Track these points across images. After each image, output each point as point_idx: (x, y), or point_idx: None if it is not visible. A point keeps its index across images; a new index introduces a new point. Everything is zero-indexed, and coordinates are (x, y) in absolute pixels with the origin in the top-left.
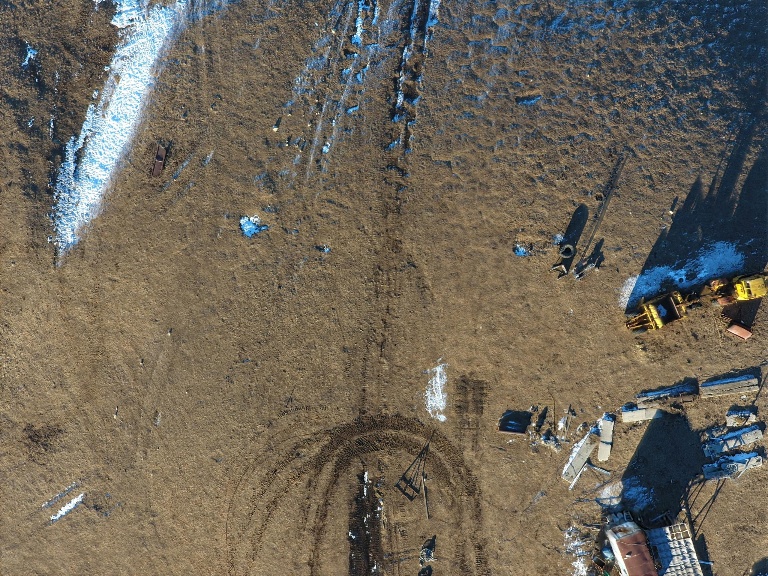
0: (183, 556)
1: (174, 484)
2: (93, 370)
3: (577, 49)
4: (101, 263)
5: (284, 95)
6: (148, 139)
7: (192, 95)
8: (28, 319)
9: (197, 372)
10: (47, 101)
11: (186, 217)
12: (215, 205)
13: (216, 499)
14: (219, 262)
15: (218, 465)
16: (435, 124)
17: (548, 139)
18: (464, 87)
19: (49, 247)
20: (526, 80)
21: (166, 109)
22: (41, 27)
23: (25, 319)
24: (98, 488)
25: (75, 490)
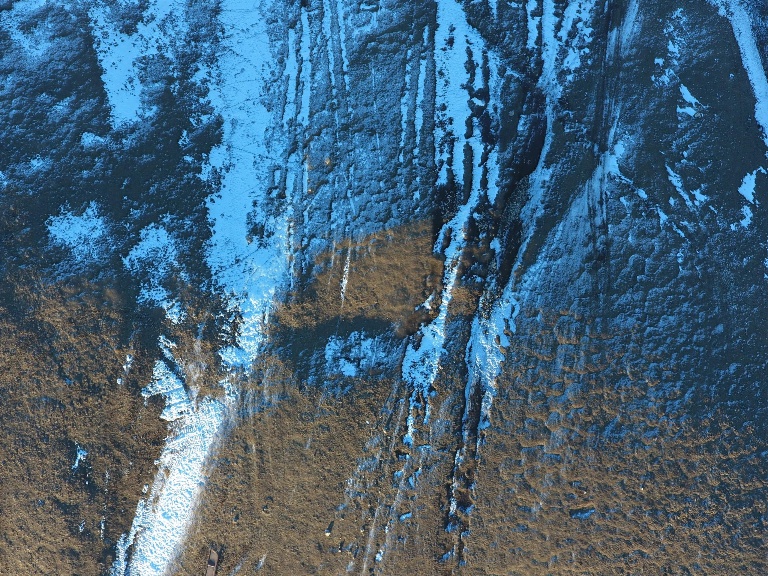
0: None
1: None
2: None
3: (630, 459)
4: None
5: (336, 497)
6: (200, 542)
7: (243, 497)
8: None
9: None
10: (97, 503)
11: None
12: None
13: None
14: None
15: None
16: (489, 536)
17: (603, 556)
18: (517, 497)
19: None
20: (580, 492)
21: (217, 511)
22: (90, 427)
23: None
24: None
25: None
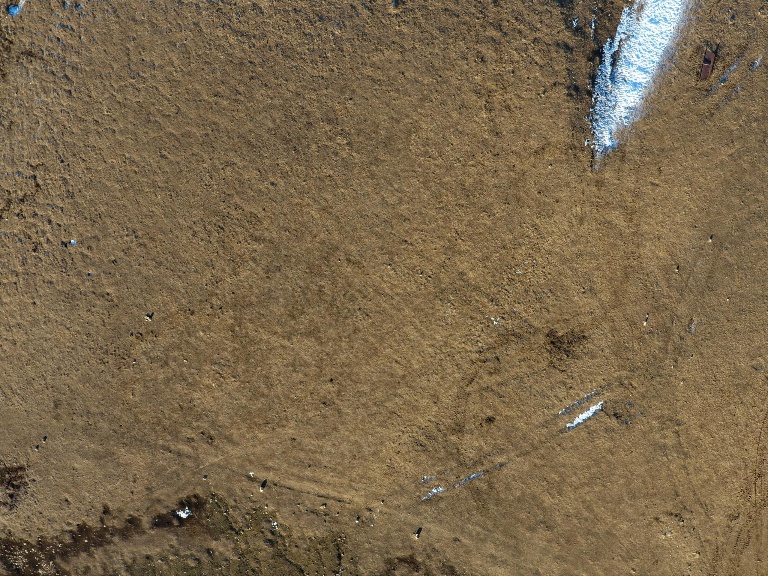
0: (707, 466)
1: (707, 392)
2: (625, 276)
3: None
4: (643, 167)
5: None
6: (694, 42)
7: None
8: (559, 223)
9: (740, 279)
10: (589, 1)
11: (734, 122)
12: (764, 110)
13: (752, 408)
14: (767, 168)
15: (758, 374)
16: None
17: None
18: None
19: (586, 150)
20: None
21: (712, 12)
22: None
23: (556, 223)
24: (620, 396)
25: (595, 397)
